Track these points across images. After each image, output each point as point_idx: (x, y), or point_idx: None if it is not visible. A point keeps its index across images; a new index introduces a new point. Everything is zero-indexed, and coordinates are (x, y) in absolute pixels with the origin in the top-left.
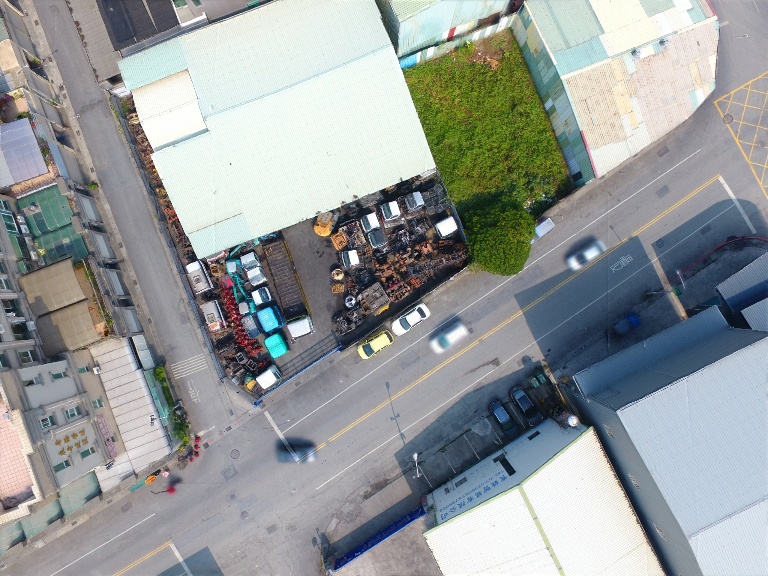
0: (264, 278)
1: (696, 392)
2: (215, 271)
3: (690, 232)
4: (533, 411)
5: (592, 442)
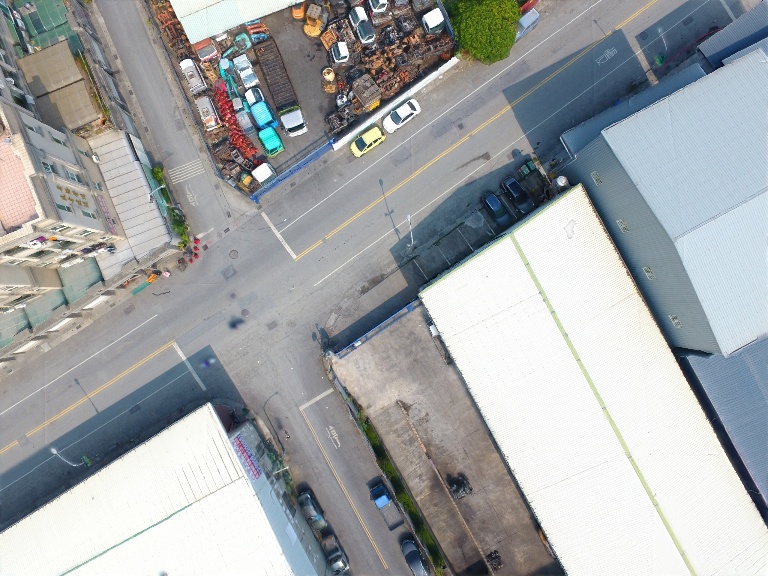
0: (257, 79)
1: (678, 109)
2: (208, 70)
3: (673, 24)
4: (524, 197)
5: (581, 198)
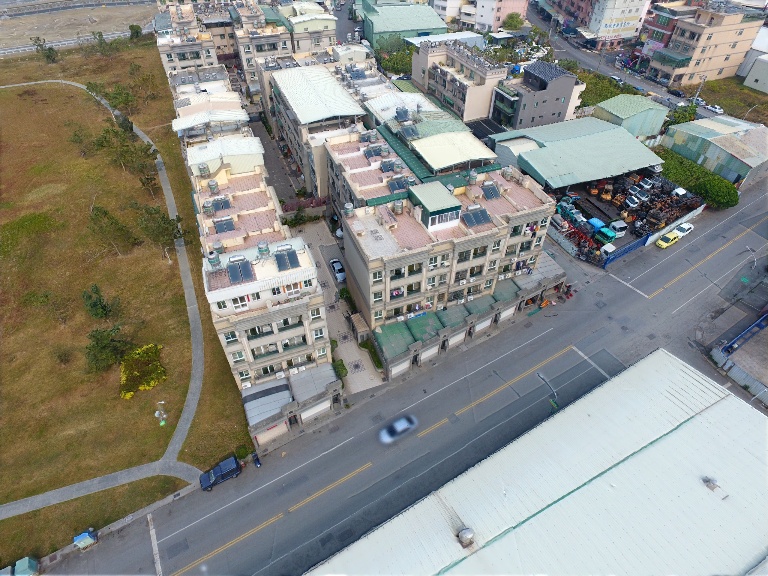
0: (581, 214)
1: None
2: None
3: None
4: None
5: None
